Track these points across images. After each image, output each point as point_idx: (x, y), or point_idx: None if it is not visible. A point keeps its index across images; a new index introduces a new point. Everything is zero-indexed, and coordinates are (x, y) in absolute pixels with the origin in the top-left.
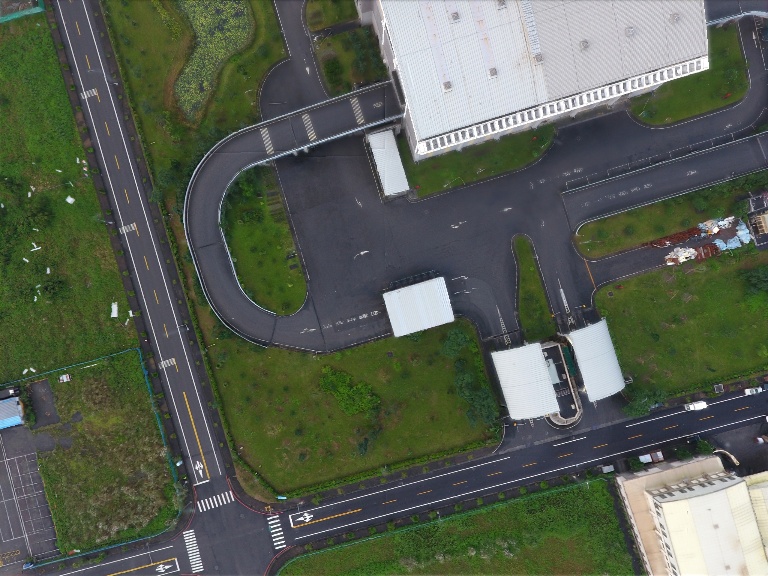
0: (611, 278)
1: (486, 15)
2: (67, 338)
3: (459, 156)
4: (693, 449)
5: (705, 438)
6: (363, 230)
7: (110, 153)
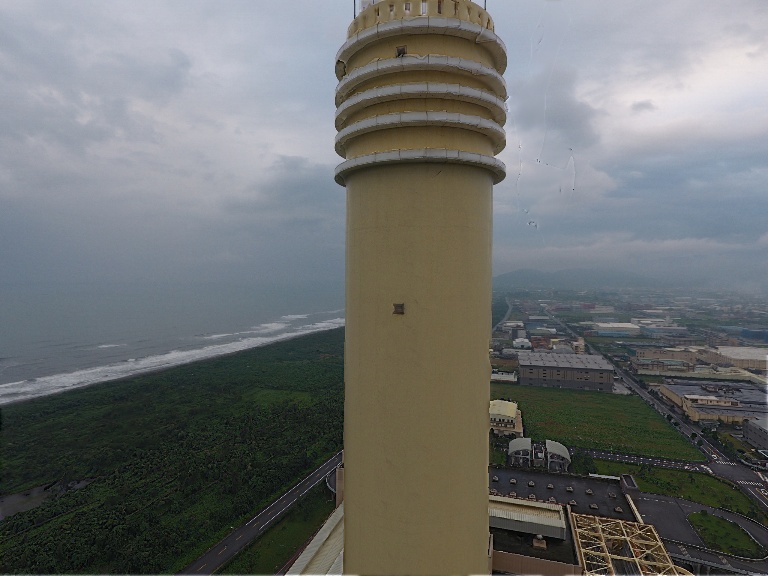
0: None
1: None
2: None
3: None
4: None
5: None
6: None
7: None
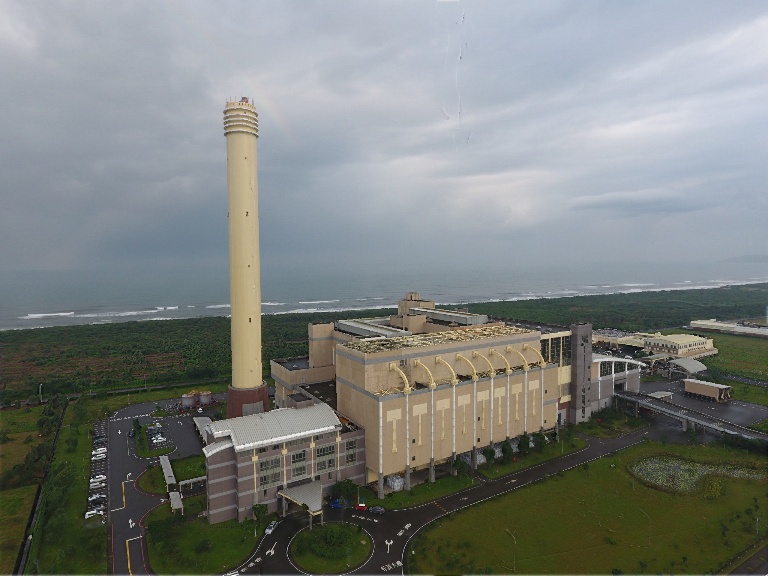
0: None
1: None
2: None
3: None
4: None
5: None
6: None
7: None
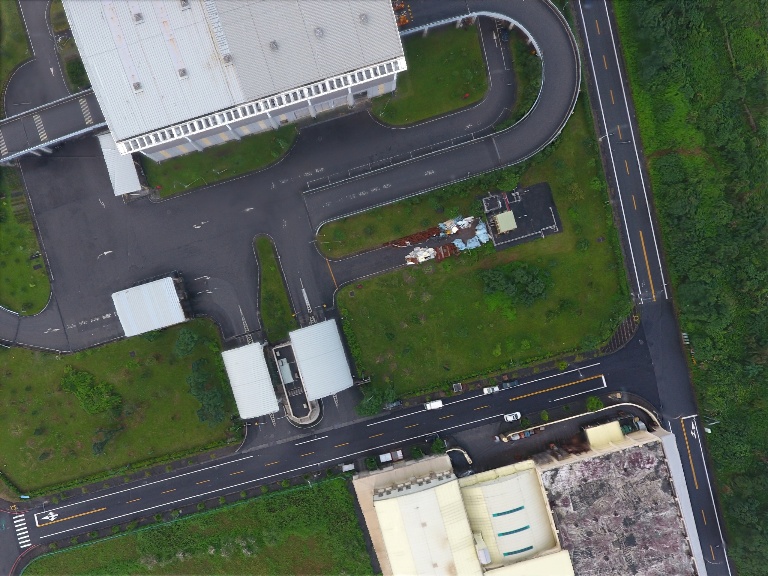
0: (353, 278)
1: (170, 16)
2: None
3: (201, 156)
4: (430, 448)
5: (445, 437)
6: (106, 230)
7: None
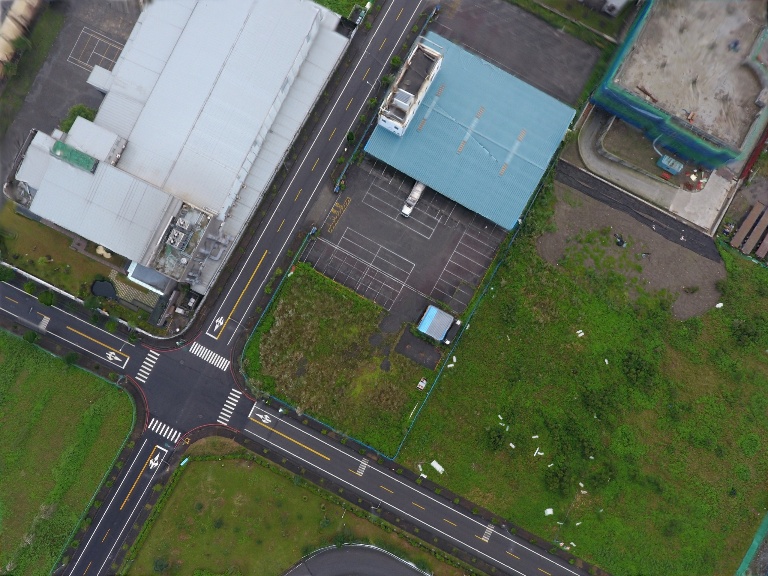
0: None
1: None
2: (450, 414)
3: None
4: None
5: None
6: None
7: (557, 573)
